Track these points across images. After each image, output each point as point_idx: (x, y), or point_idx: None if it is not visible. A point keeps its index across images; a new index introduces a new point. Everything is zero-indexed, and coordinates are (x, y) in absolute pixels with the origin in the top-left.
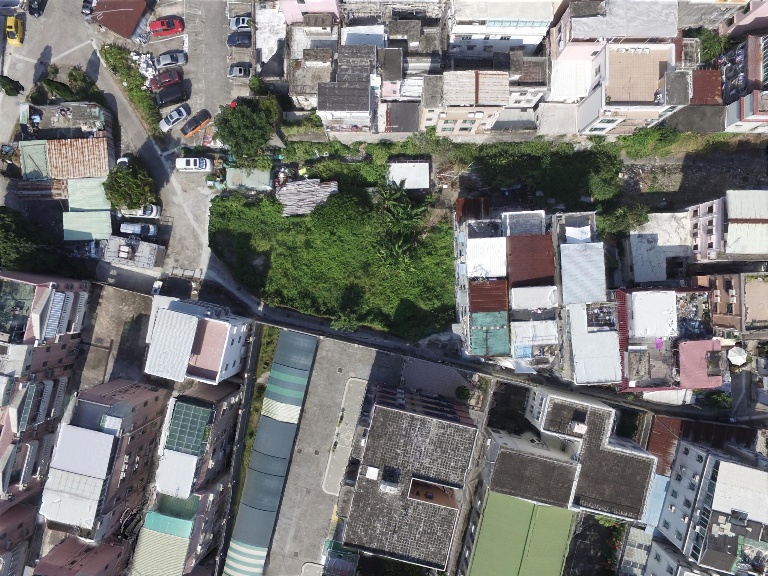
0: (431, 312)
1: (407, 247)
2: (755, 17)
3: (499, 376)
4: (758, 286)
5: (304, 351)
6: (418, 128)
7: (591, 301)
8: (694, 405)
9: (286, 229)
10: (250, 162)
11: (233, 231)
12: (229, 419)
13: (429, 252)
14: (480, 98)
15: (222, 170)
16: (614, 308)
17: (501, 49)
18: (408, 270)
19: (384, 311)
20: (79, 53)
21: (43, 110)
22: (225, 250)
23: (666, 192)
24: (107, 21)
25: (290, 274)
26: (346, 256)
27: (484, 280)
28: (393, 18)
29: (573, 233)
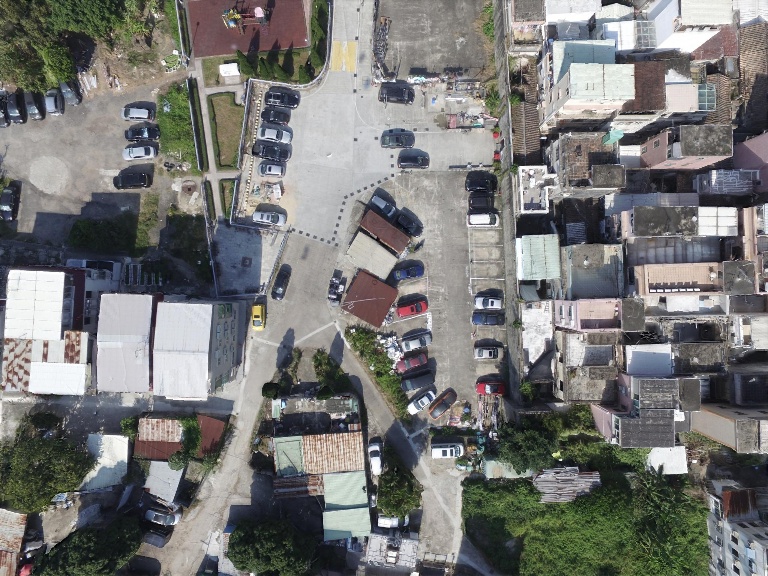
0: None
1: None
2: None
3: None
4: None
5: None
6: (690, 429)
7: None
8: None
9: (541, 513)
10: None
11: (488, 517)
12: None
13: (683, 531)
14: None
15: (475, 455)
16: None
17: None
18: None
19: None
20: (322, 335)
21: (288, 396)
22: (476, 533)
23: None
24: (358, 310)
25: (545, 557)
26: (599, 536)
27: None
28: (675, 331)
29: None
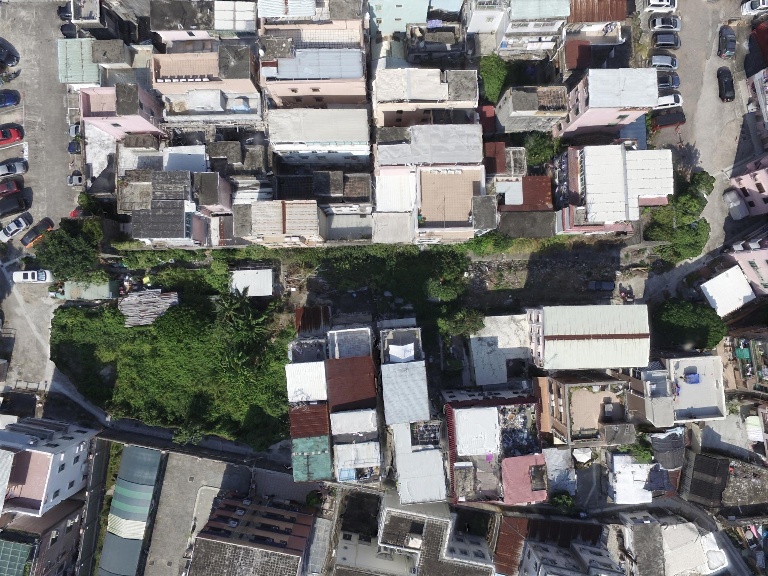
0: (279, 419)
1: (247, 359)
2: (577, 126)
3: (347, 482)
4: (585, 395)
5: (147, 466)
6: None
7: (414, 420)
8: (543, 502)
9: (131, 339)
10: (84, 278)
11: (76, 343)
12: (69, 540)
13: (277, 357)
14: (288, 228)
15: (63, 281)
16: (438, 426)
17: (336, 158)
18: (248, 382)
19: (233, 418)
20: None
21: None
22: (70, 361)
23: (512, 289)
24: None
25: (136, 384)
26: (194, 363)
27: (303, 405)
28: (217, 136)
29: (396, 351)
